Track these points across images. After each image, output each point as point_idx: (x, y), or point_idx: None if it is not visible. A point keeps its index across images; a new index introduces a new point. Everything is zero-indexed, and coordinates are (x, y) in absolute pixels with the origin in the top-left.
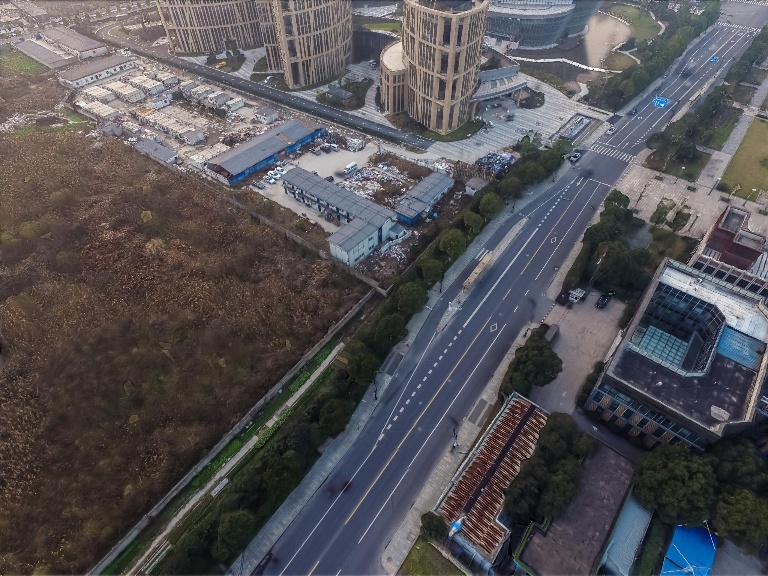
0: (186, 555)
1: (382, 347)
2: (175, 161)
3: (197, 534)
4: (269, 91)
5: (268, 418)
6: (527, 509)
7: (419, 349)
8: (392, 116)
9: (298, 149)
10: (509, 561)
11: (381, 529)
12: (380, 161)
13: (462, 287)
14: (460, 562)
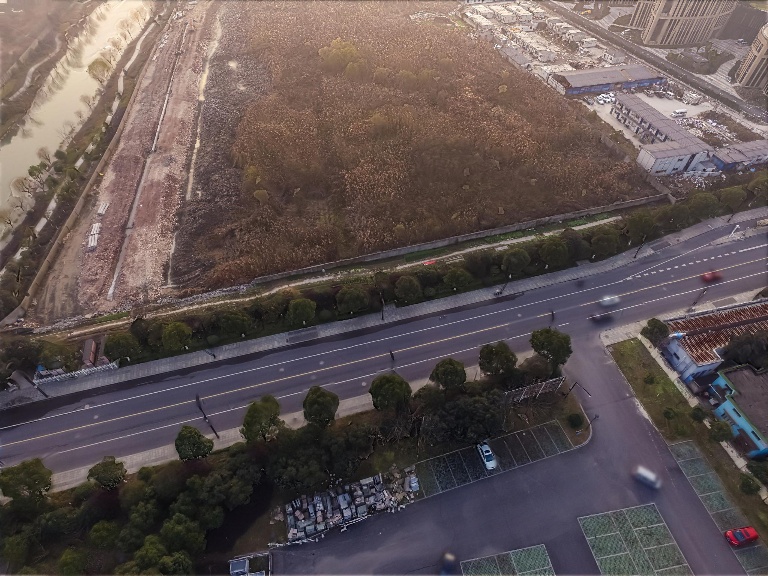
0: (480, 259)
1: (658, 227)
2: (526, 68)
3: (489, 253)
4: (622, 41)
5: (546, 231)
6: (749, 352)
7: (687, 247)
8: (742, 88)
9: (633, 88)
10: (712, 374)
11: (607, 320)
12: (711, 118)
13: (753, 227)
14: (666, 360)
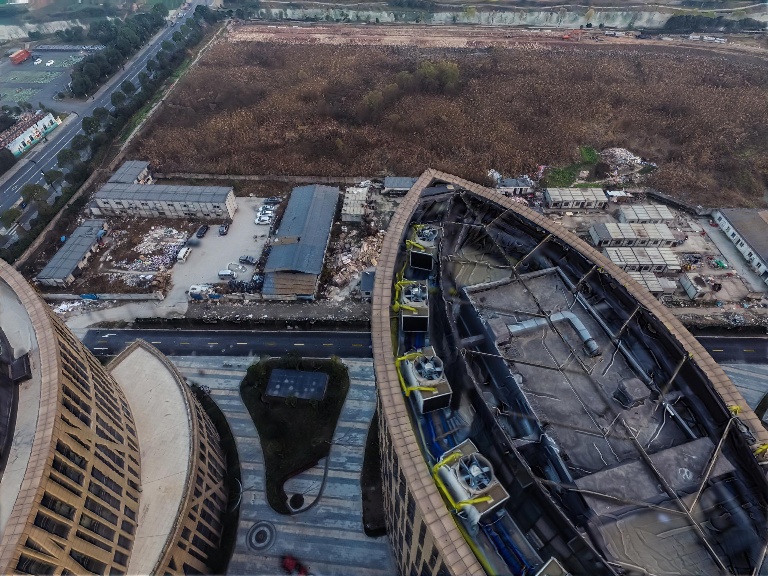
0: None
1: None
2: None
3: (145, 87)
4: None
5: None
6: None
7: None
8: None
9: None
10: None
11: None
12: None
13: None
14: None
